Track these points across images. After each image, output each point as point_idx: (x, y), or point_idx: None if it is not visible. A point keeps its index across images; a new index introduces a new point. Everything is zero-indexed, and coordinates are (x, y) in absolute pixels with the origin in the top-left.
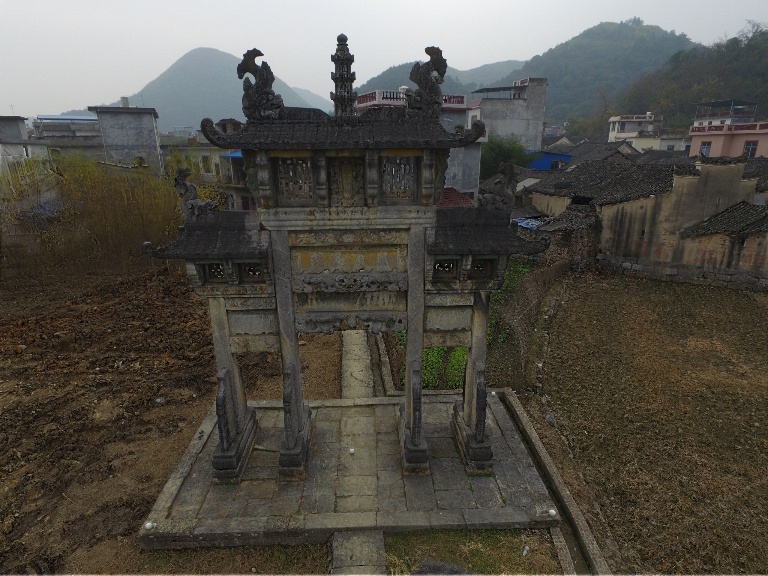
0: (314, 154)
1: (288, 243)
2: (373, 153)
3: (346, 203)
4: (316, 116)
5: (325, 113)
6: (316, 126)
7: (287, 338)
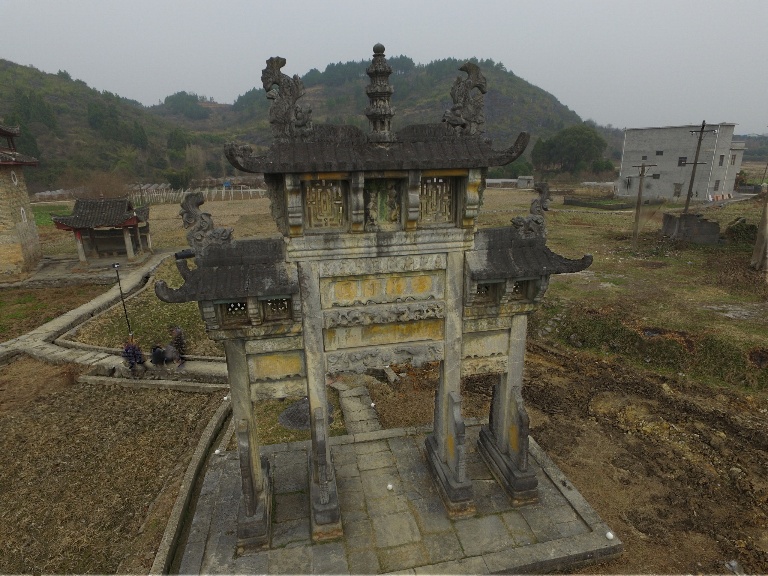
0: None
1: None
2: None
3: None
4: None
5: None
6: None
7: None
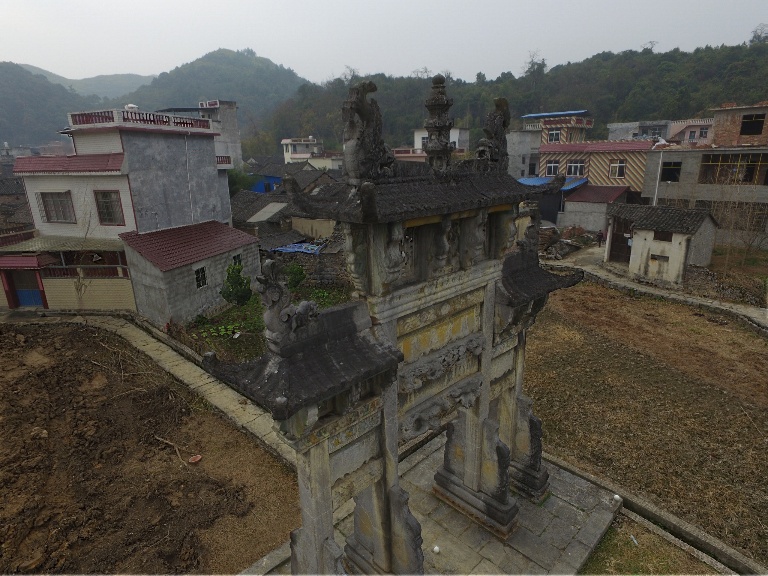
0: (443, 219)
1: (396, 334)
2: (485, 211)
3: (447, 270)
4: (425, 171)
5: (431, 167)
6: (428, 184)
7: (392, 455)
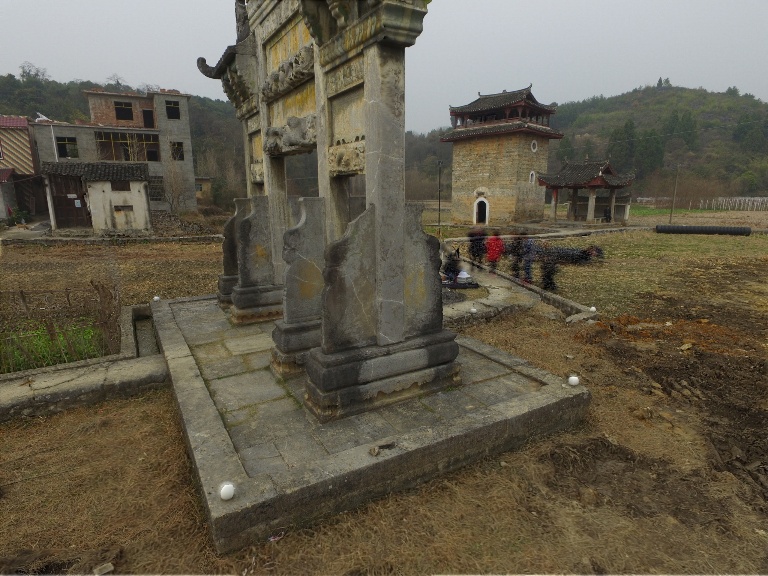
0: None
1: None
2: None
3: None
4: None
5: None
6: None
7: None
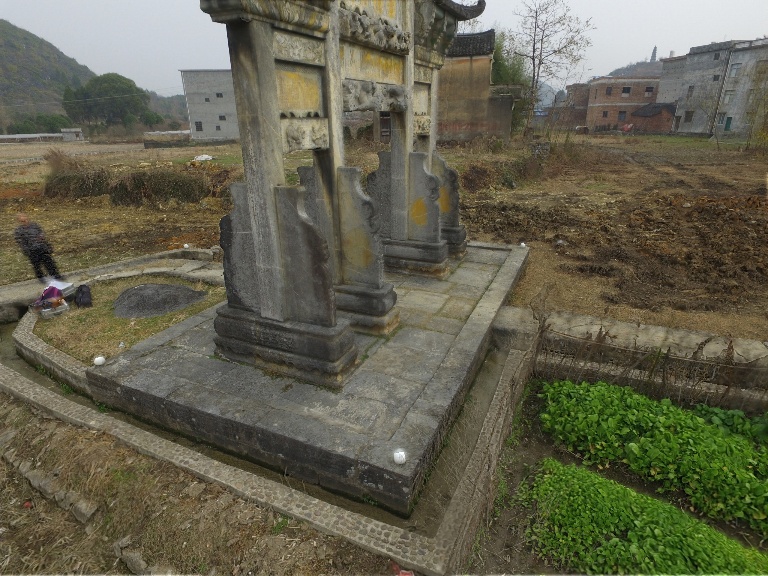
0: None
1: None
2: None
3: None
4: None
5: None
6: None
7: None
